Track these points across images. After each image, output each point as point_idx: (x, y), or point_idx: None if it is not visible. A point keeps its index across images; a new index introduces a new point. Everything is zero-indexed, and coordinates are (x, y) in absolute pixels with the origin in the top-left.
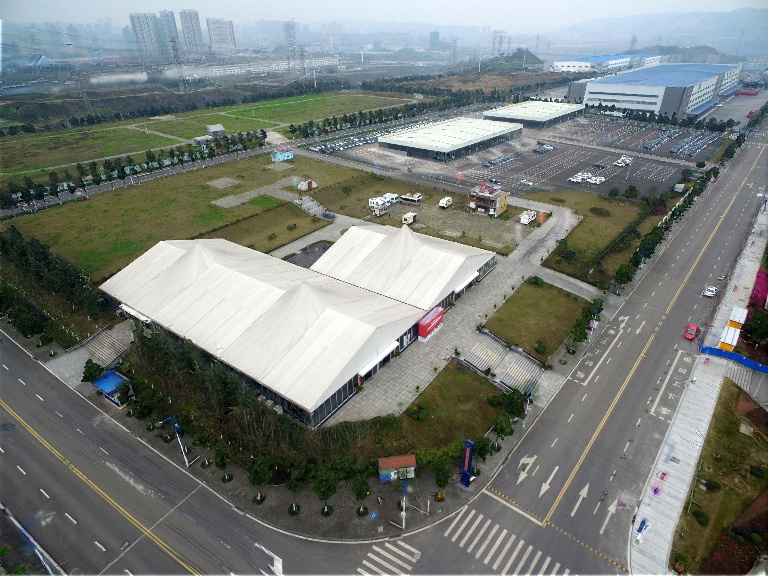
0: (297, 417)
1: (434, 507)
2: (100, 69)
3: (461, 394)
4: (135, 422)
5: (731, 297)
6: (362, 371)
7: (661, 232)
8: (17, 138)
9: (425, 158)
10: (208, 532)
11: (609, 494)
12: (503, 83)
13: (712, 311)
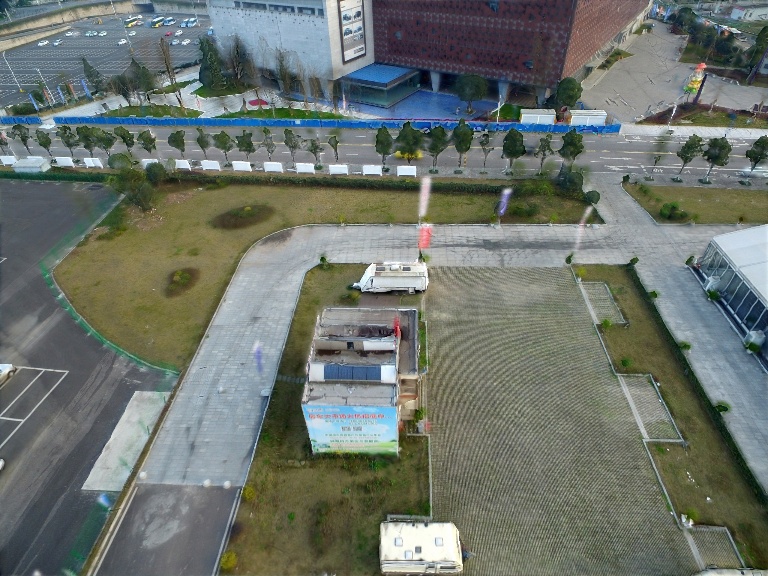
0: None
1: None
2: None
3: None
4: None
5: None
6: None
7: None
8: None
9: None
10: None
11: None
12: None
13: None
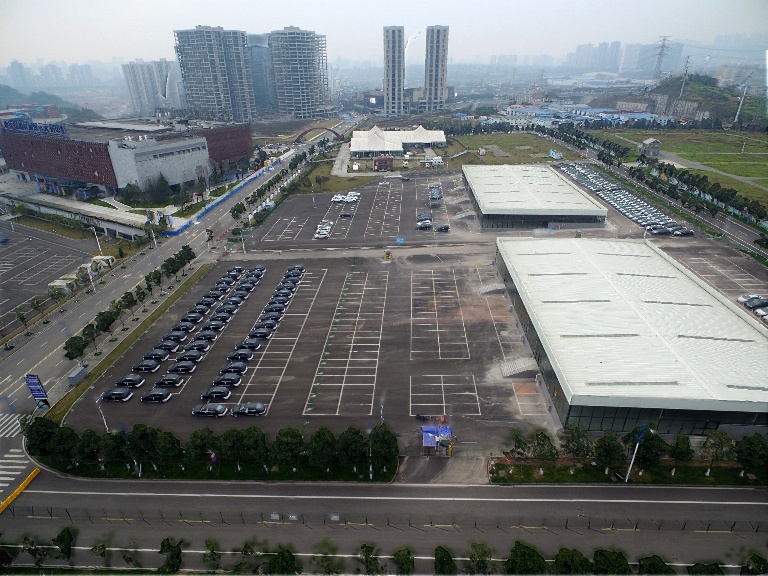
0: None
1: None
2: None
3: None
4: None
5: None
6: None
7: None
8: None
9: None
10: None
11: None
12: None
13: None
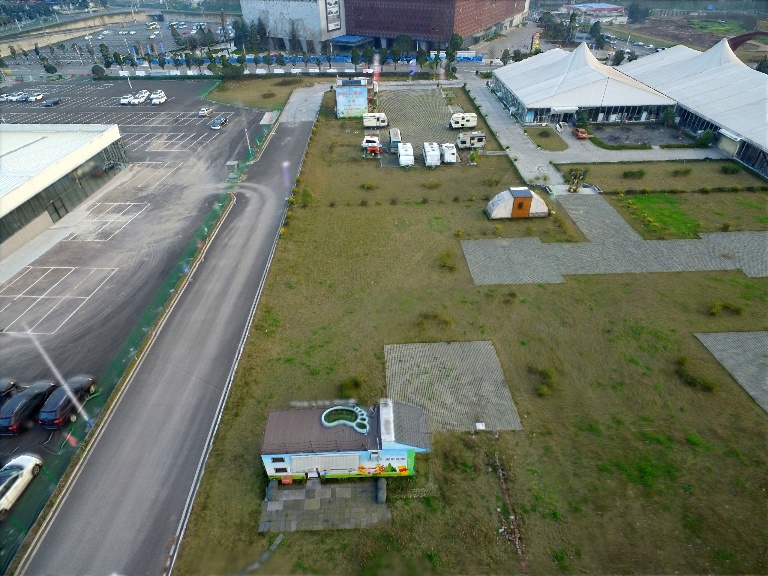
0: None
1: None
2: None
3: None
4: None
5: None
6: None
7: None
8: None
9: (93, 187)
10: None
11: None
12: None
13: None
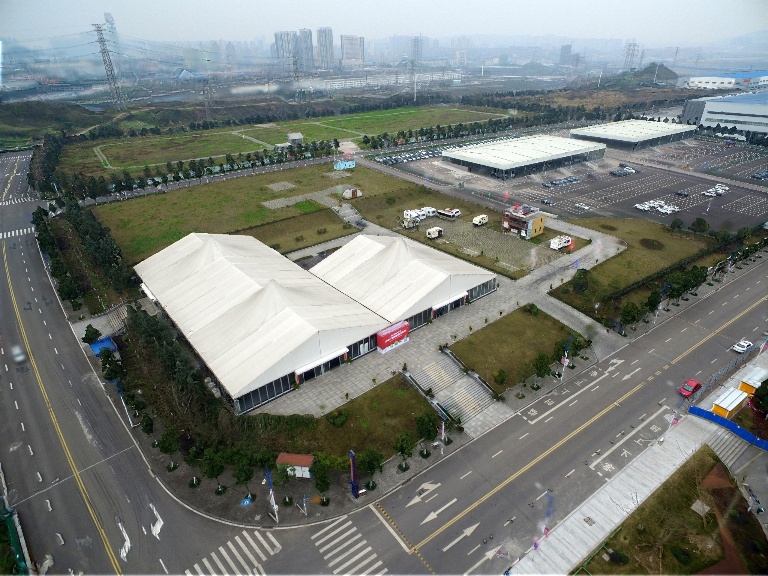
0: (230, 402)
1: (315, 509)
2: (229, 81)
3: (392, 409)
4: (112, 383)
5: (767, 356)
6: (299, 370)
7: (704, 272)
8: (144, 138)
9: (484, 174)
10: (120, 485)
11: (495, 539)
12: (616, 100)
13: (732, 369)
